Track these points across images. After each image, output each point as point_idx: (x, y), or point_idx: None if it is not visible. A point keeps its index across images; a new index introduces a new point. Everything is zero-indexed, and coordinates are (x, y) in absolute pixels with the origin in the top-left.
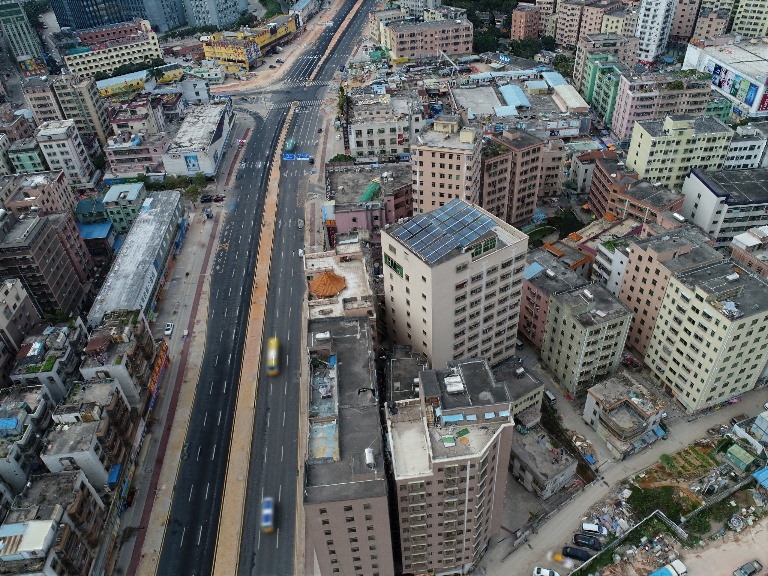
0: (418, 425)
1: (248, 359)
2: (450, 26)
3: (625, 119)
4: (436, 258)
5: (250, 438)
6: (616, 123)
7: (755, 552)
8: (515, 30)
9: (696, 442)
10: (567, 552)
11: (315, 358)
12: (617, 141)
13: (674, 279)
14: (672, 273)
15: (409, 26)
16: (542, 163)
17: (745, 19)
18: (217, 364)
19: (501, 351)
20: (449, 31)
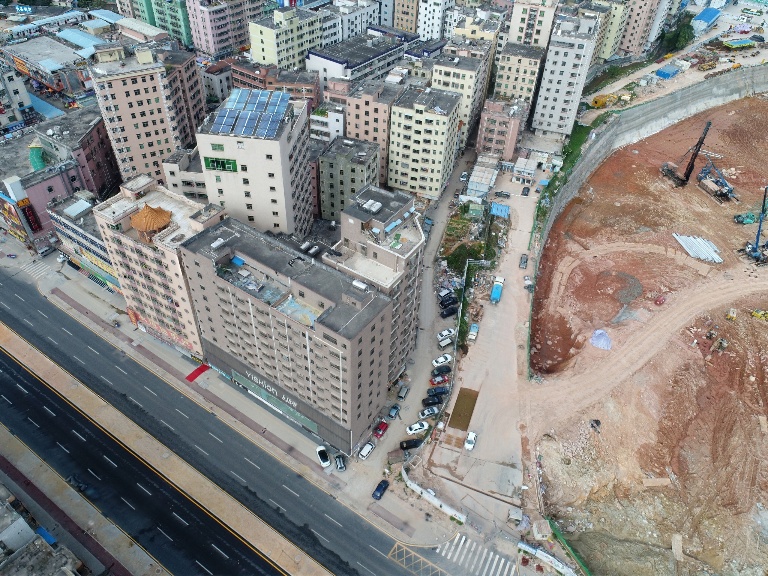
0: (357, 256)
1: (46, 375)
2: None
3: (209, 34)
4: (274, 133)
5: (135, 425)
6: (199, 41)
7: (518, 252)
8: None
9: (449, 217)
10: (445, 314)
11: (219, 269)
12: (208, 58)
13: (395, 107)
14: (388, 106)
15: None
16: None
17: None
18: (11, 401)
19: (309, 218)
20: None
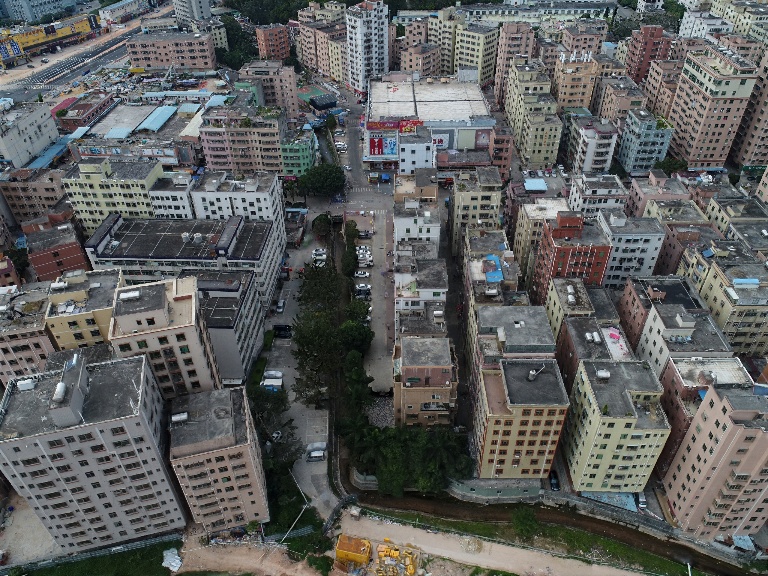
0: None
1: None
2: (185, 39)
3: None
4: None
5: None
6: None
7: None
8: (260, 48)
9: None
10: None
11: None
12: None
13: None
14: None
15: (150, 36)
16: (37, 192)
17: (462, 55)
18: None
19: None
20: (182, 44)
